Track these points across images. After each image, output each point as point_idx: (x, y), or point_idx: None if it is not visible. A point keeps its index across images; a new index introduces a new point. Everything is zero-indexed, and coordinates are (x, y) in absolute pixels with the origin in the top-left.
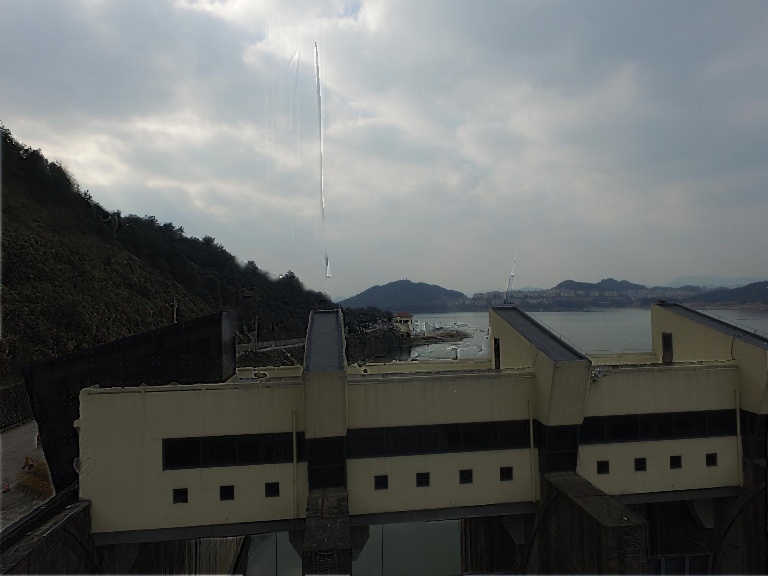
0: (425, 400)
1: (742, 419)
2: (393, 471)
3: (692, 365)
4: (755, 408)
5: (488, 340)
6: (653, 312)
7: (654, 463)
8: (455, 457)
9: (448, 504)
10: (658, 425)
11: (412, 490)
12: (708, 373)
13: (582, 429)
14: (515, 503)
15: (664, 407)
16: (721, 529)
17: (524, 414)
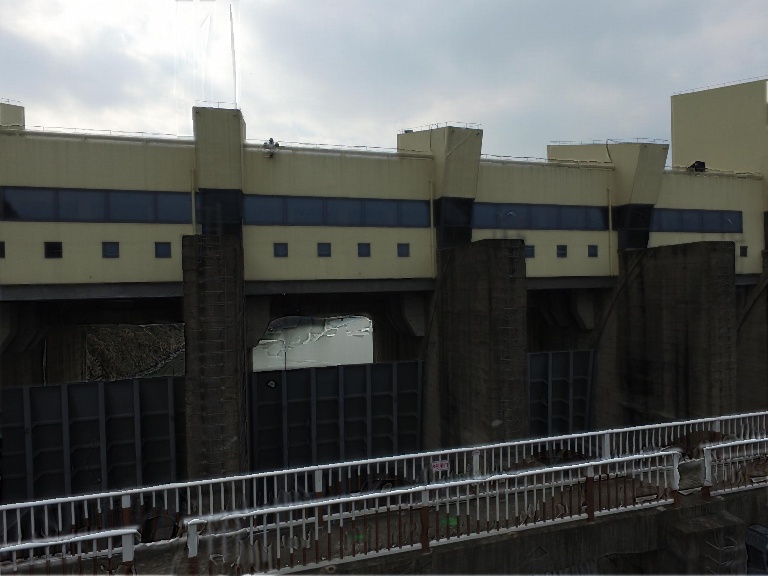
0: (57, 159)
1: (435, 210)
2: (13, 238)
3: (384, 151)
4: (440, 192)
5: None
6: (397, 142)
7: (340, 249)
8: (97, 227)
9: (87, 279)
10: (348, 213)
11: (39, 261)
12: (401, 161)
13: (258, 208)
14: (174, 283)
15: (353, 192)
16: (427, 333)
17: (186, 186)
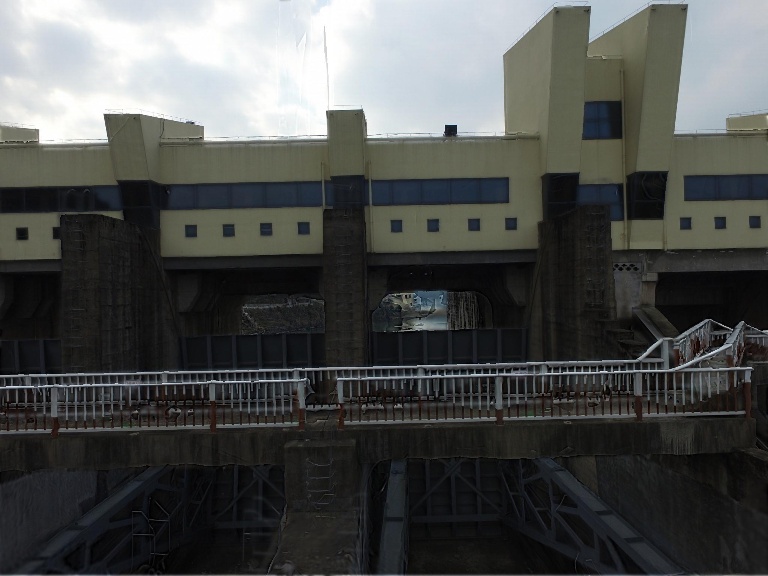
0: None
1: None
2: None
3: (79, 142)
4: None
5: (441, 300)
6: None
7: (37, 233)
8: None
9: None
10: (49, 200)
11: None
12: (94, 150)
13: None
14: None
15: (49, 181)
16: None
17: None
